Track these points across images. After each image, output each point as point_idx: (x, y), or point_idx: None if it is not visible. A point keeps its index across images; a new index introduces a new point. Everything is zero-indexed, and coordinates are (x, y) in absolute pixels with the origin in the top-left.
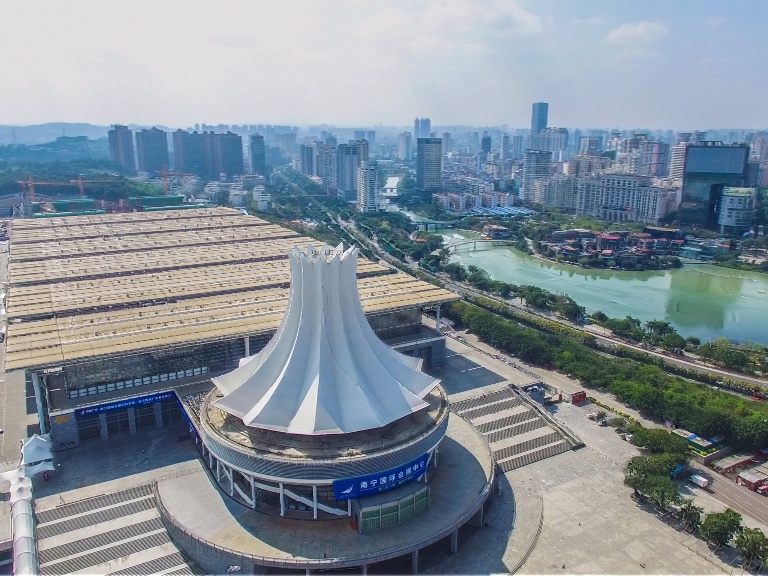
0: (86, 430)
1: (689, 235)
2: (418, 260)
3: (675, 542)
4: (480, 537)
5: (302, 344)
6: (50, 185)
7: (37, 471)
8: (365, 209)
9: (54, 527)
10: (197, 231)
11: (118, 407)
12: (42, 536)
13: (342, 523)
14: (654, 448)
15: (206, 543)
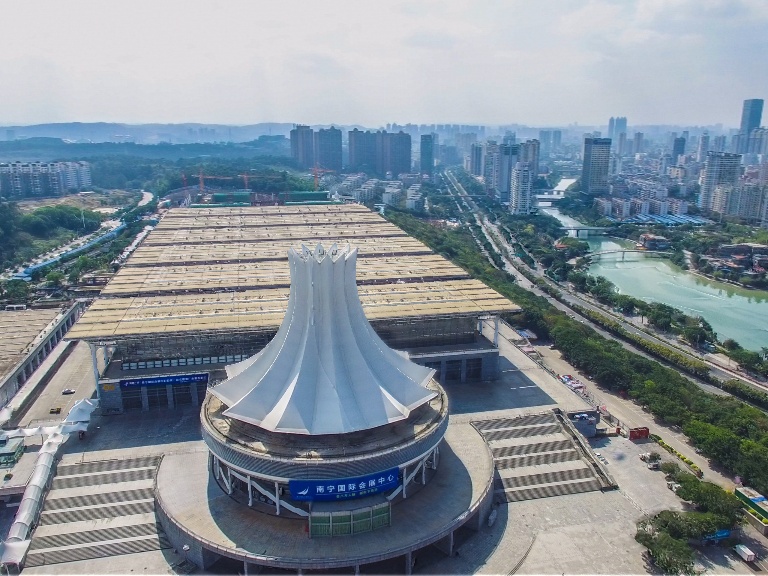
0: (132, 400)
1: None
2: (548, 267)
3: None
4: (444, 565)
5: (292, 341)
6: (215, 179)
7: (72, 430)
8: (515, 211)
9: (67, 481)
10: (313, 226)
11: (158, 382)
12: (55, 487)
13: (299, 524)
14: (697, 504)
15: (170, 519)
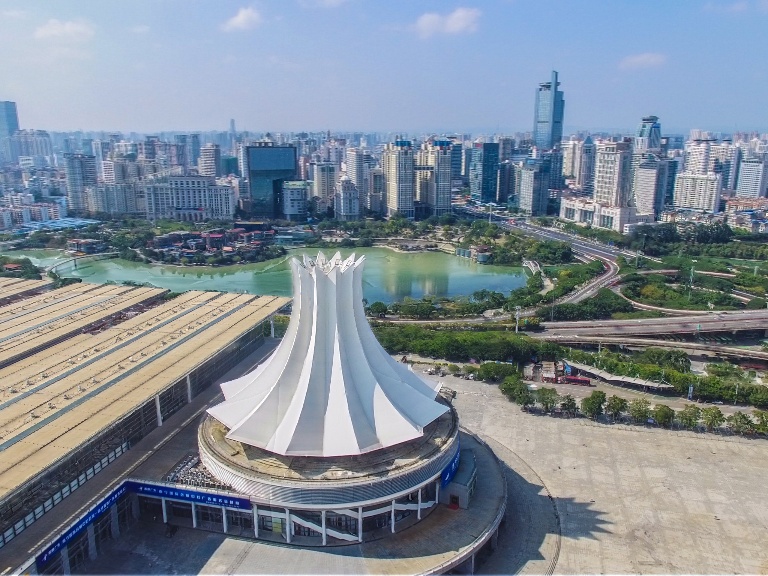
0: None
1: (273, 225)
2: None
3: (577, 425)
4: None
5: (344, 360)
6: None
7: None
8: None
9: None
10: None
11: (79, 530)
12: None
13: (442, 511)
14: (498, 377)
15: None
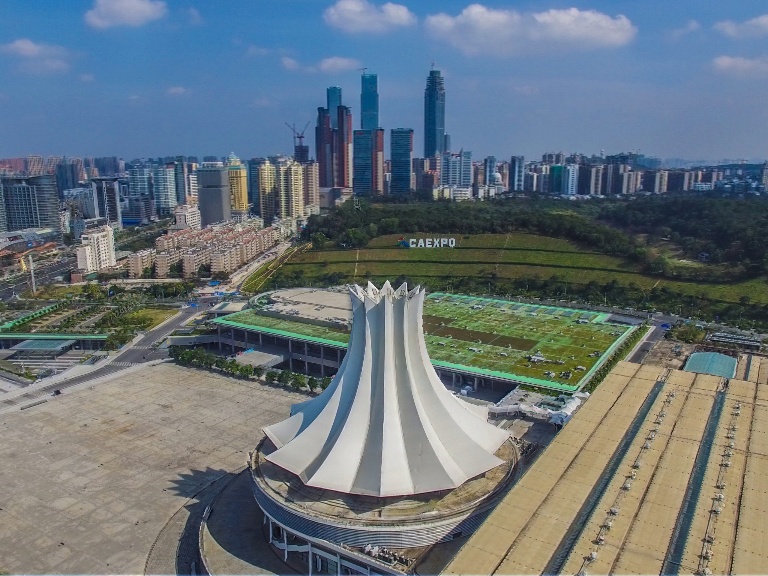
0: None
1: None
2: None
3: (10, 575)
4: None
5: None
6: None
7: None
8: None
9: None
10: None
11: None
12: None
13: None
14: None
15: None
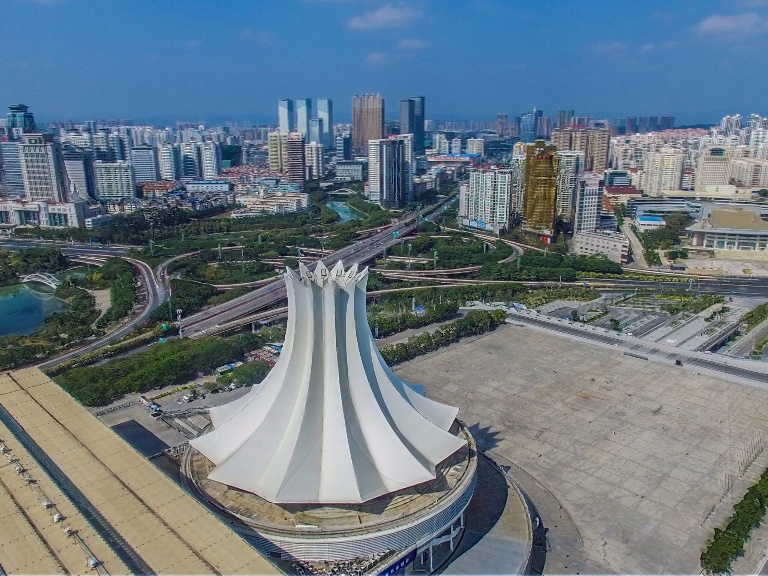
0: None
1: None
2: None
3: None
4: None
5: None
6: None
7: None
8: None
9: None
10: None
11: None
12: None
13: None
14: (259, 375)
15: None
